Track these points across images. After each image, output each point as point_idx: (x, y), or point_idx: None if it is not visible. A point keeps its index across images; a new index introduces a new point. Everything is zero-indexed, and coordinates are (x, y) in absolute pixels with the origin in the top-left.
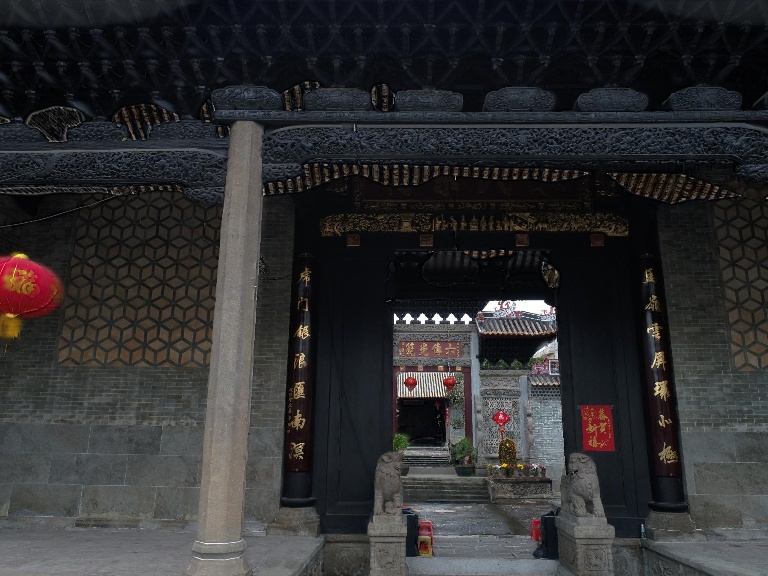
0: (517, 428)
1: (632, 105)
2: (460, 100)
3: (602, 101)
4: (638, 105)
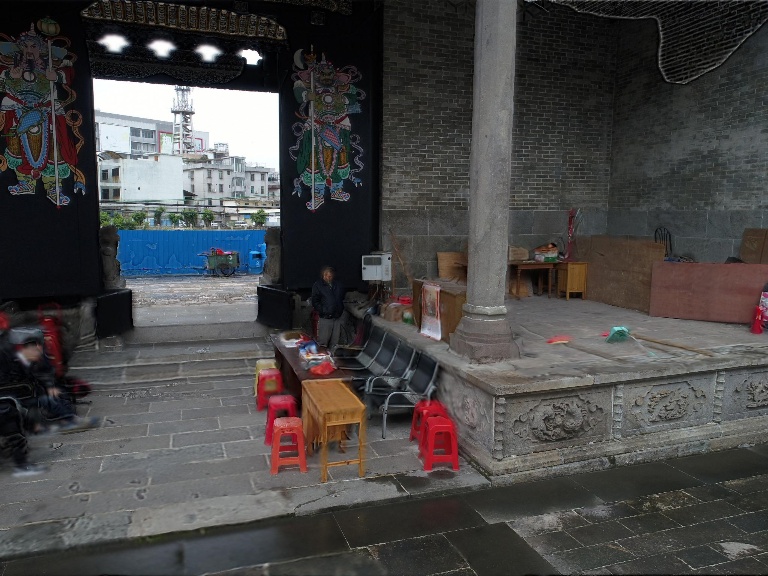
0: None
1: (129, 54)
2: (215, 59)
3: (145, 54)
4: (126, 54)
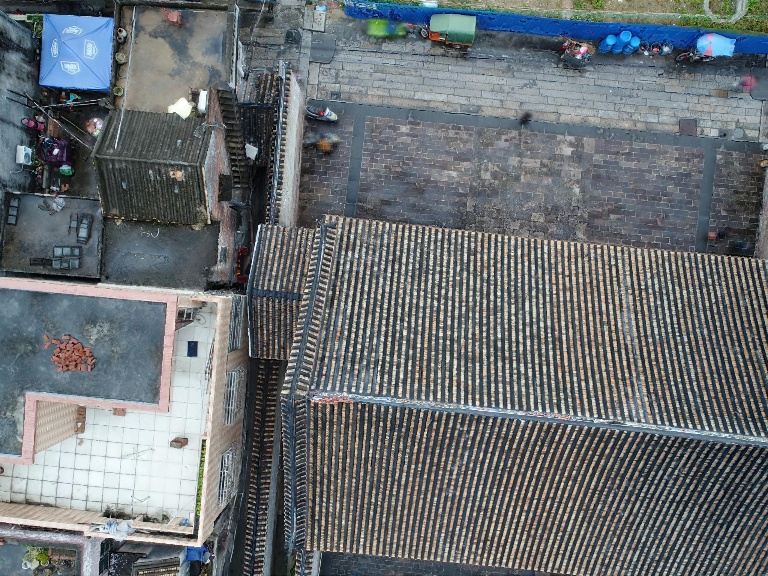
0: None
1: None
2: None
3: None
4: None
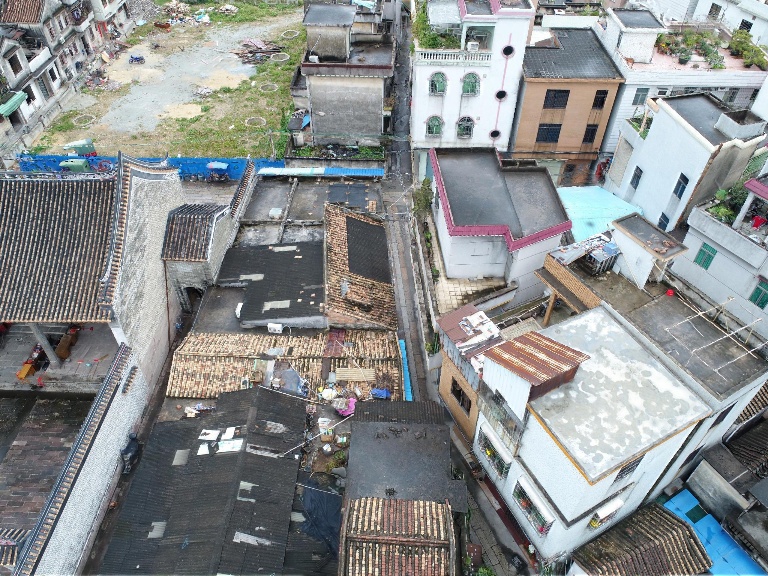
0: None
1: None
2: None
3: None
4: None
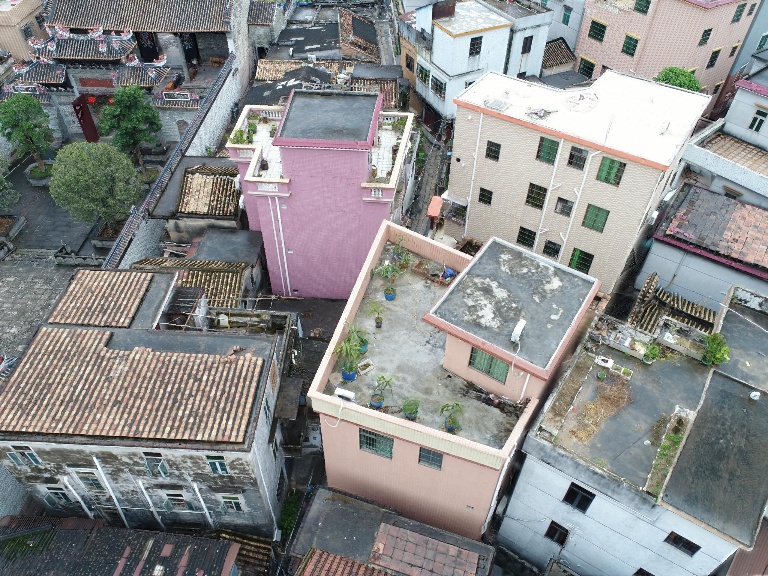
0: (68, 119)
1: None
2: None
3: None
4: None
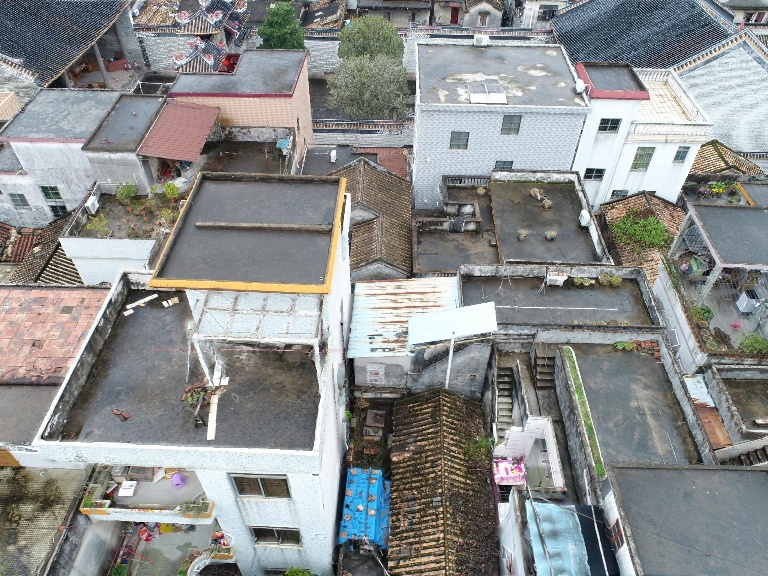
0: None
1: None
2: None
3: None
4: None
